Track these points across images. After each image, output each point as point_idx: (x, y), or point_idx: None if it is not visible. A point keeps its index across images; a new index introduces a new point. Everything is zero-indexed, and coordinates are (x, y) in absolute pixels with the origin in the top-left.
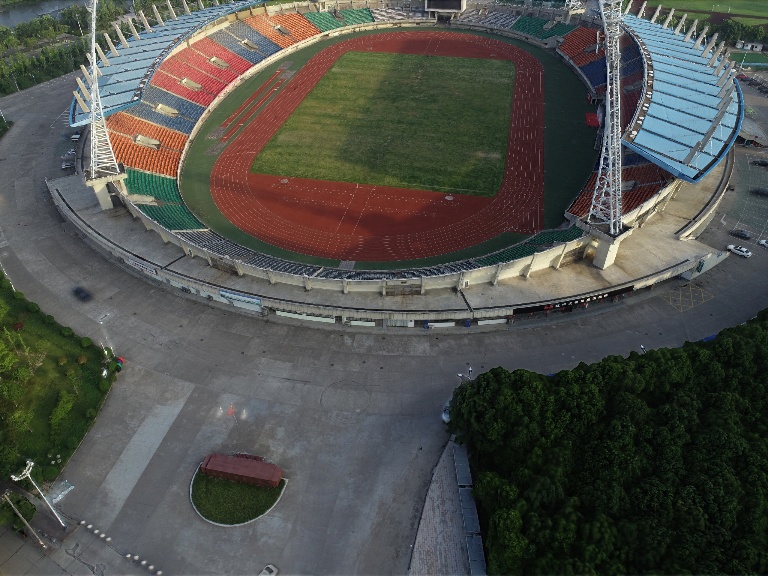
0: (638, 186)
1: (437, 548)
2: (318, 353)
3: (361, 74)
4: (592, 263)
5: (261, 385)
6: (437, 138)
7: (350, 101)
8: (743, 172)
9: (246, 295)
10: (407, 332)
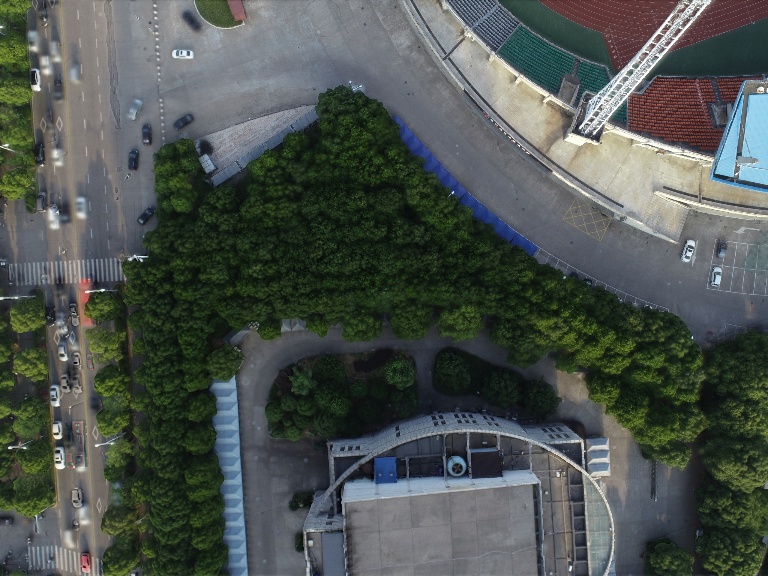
0: None
1: (256, 133)
2: None
3: None
4: (568, 128)
5: None
6: None
7: None
8: None
9: None
10: (411, 21)
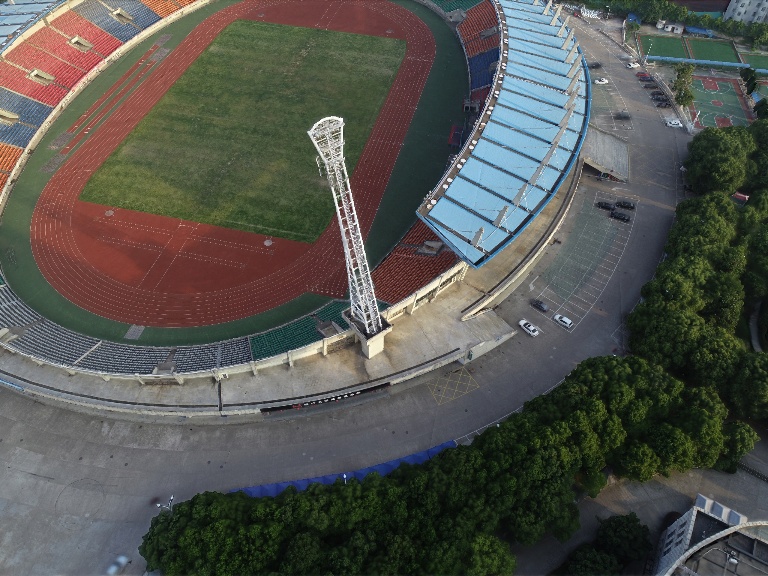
0: (443, 250)
1: None
2: (72, 444)
3: (238, 56)
4: (361, 350)
5: (7, 481)
6: (285, 156)
7: (213, 98)
8: (582, 217)
9: (8, 381)
10: (164, 421)
